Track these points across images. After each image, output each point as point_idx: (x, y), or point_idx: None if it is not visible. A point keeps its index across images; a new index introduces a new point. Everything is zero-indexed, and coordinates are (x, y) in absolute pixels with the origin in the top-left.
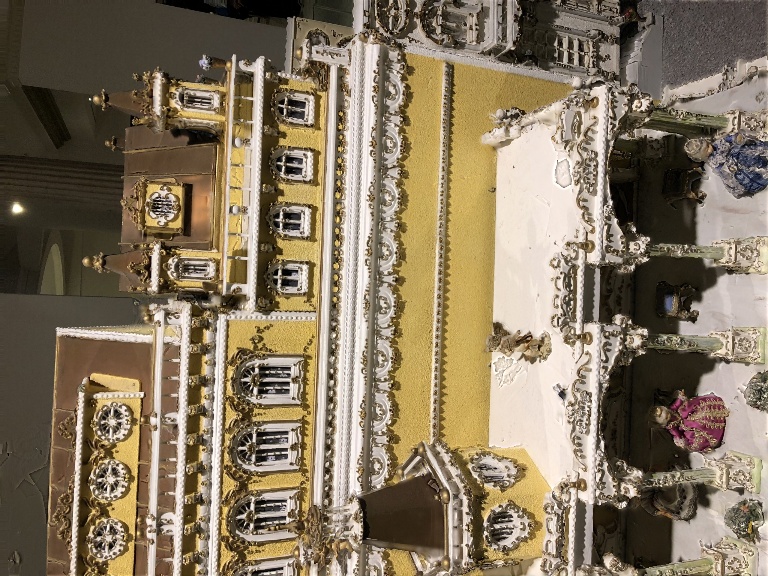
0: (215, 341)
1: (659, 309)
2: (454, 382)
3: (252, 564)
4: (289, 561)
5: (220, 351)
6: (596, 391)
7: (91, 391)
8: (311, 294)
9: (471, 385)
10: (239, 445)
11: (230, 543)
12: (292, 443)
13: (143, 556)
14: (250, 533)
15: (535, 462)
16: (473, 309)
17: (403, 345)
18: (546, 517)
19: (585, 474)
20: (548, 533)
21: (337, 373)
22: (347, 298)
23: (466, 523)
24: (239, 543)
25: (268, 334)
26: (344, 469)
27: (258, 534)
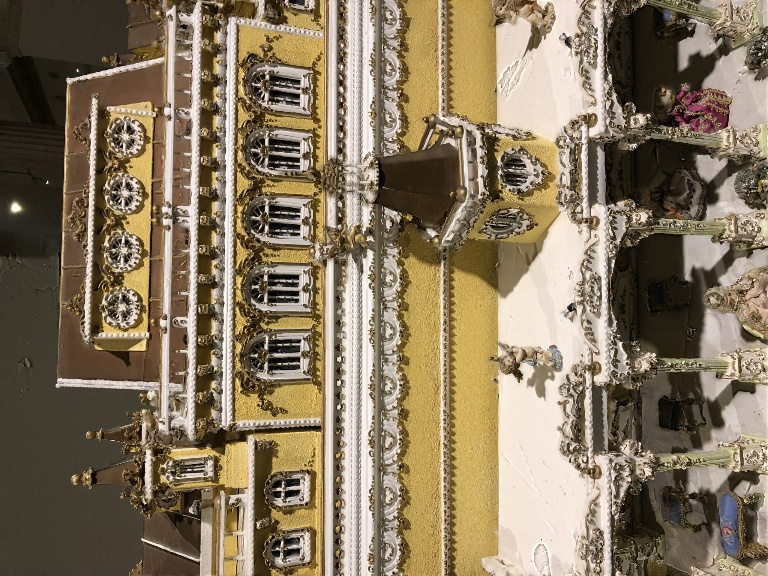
0: (226, 45)
1: (658, 25)
2: (461, 104)
3: (268, 264)
4: (305, 268)
5: (231, 54)
6: (601, 23)
7: None
8: (318, 14)
9: (478, 110)
10: (252, 147)
11: (246, 241)
12: (304, 152)
13: (158, 270)
14: (265, 235)
15: (545, 136)
16: (476, 36)
17: (410, 60)
18: (559, 152)
19: (595, 108)
20: (562, 167)
21: (346, 79)
22: (354, 4)
23: (480, 156)
24: (254, 244)
25: (277, 45)
26: (356, 169)
27: (273, 237)
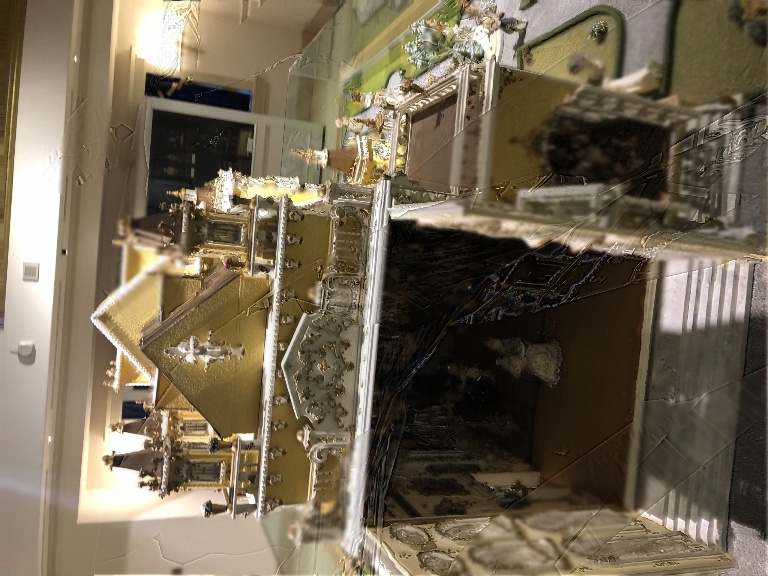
0: None
1: None
2: None
3: None
4: None
5: None
6: None
7: (124, 375)
8: None
9: None
10: None
11: None
12: None
13: None
14: None
15: None
16: None
17: None
18: None
19: None
20: None
21: None
22: None
23: None
24: None
25: None
26: None
27: None
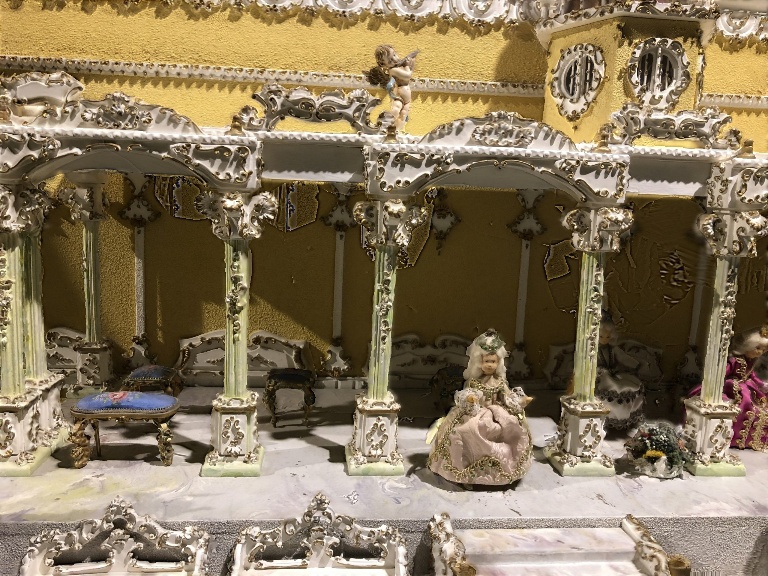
0: None
1: None
2: None
3: None
4: None
5: None
6: None
7: None
8: None
9: None
10: None
11: None
12: None
13: None
14: None
15: None
16: None
17: (746, 55)
18: None
19: None
20: (677, 112)
21: None
22: None
23: None
24: None
25: None
26: None
27: None
